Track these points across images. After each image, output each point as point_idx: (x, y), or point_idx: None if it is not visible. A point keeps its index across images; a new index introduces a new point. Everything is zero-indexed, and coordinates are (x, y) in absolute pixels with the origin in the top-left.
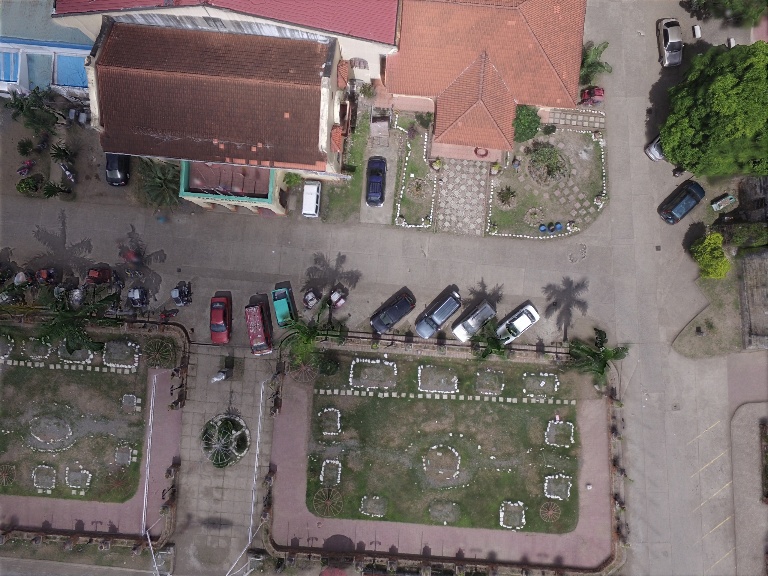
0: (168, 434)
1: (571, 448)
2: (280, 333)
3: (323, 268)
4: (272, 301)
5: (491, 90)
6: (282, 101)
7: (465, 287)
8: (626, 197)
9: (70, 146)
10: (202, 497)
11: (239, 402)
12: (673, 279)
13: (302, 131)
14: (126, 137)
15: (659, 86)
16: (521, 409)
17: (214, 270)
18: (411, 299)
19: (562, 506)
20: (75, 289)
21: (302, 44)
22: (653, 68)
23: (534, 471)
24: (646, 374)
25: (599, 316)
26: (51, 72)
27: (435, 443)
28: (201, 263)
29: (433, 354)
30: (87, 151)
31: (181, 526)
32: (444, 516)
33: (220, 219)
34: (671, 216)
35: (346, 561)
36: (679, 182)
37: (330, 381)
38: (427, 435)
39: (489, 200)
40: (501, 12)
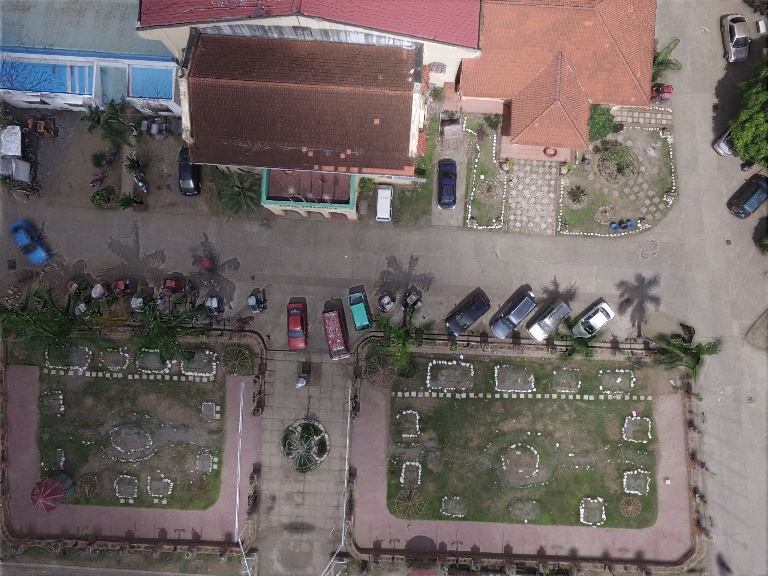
0: (248, 441)
1: (648, 443)
2: (356, 337)
3: (396, 271)
4: (347, 306)
5: (567, 90)
6: (372, 108)
7: (538, 286)
8: (695, 193)
9: (141, 157)
10: (283, 502)
11: (317, 407)
12: (744, 273)
13: (391, 137)
14: (215, 147)
15: (725, 81)
16: (598, 406)
17: (288, 276)
18: (486, 300)
19: (641, 501)
20: (156, 299)
21: (387, 50)
22: (718, 64)
23: (612, 467)
24: (720, 368)
25: (672, 311)
26: (126, 84)
27: (514, 442)
28: (275, 270)
29: (508, 354)
30: (158, 162)
31: (263, 532)
32: (525, 514)
33: (292, 226)
34: (743, 210)
35: (429, 562)
36: (747, 176)
37: (407, 383)
38: (505, 434)
39: (559, 199)
40: (579, 13)
